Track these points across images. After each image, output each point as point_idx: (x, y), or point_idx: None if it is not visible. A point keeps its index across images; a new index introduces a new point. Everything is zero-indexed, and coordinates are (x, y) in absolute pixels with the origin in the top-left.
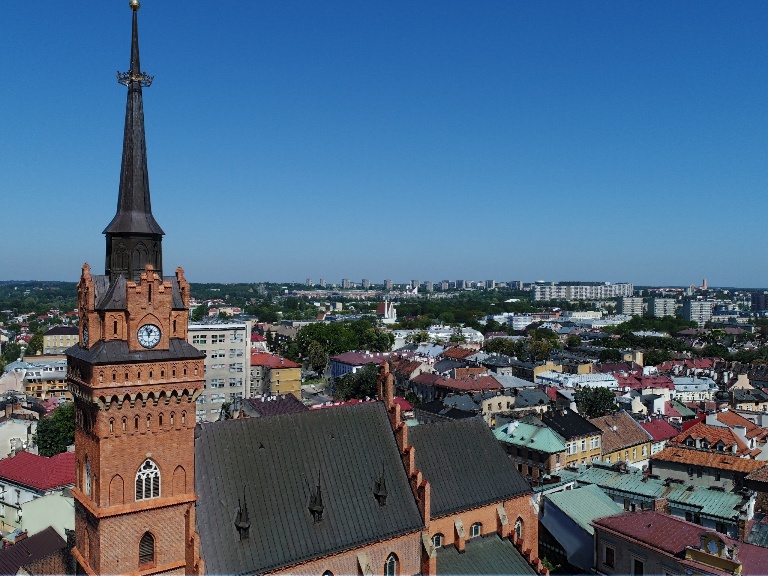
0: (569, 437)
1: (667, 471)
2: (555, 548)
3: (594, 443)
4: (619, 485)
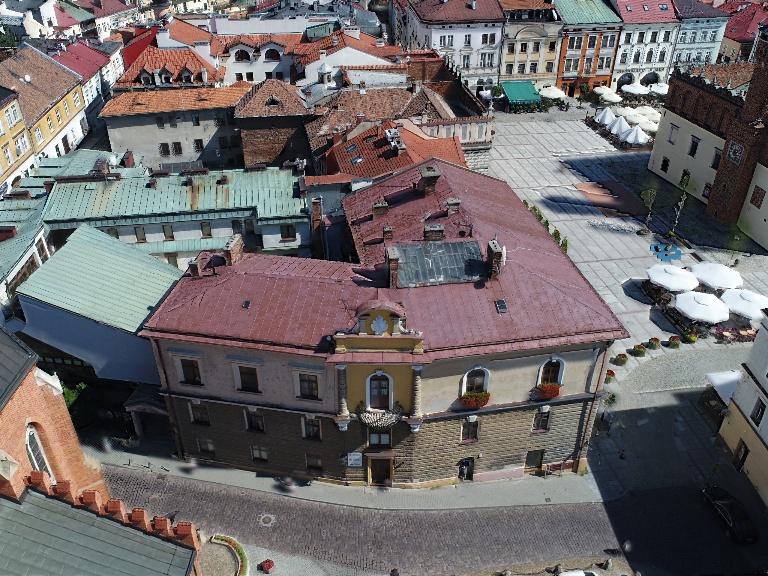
0: None
1: (129, 129)
2: (63, 360)
3: (11, 116)
4: (119, 208)
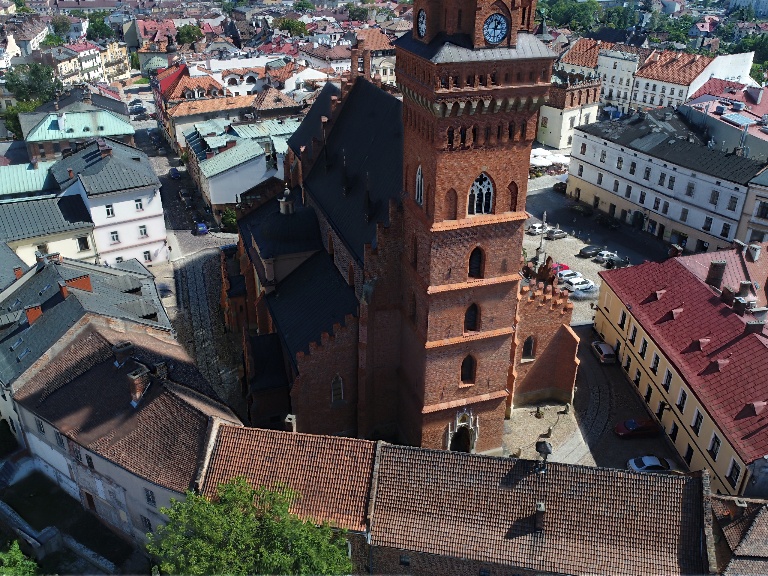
0: None
1: (189, 125)
2: None
3: None
4: (276, 131)
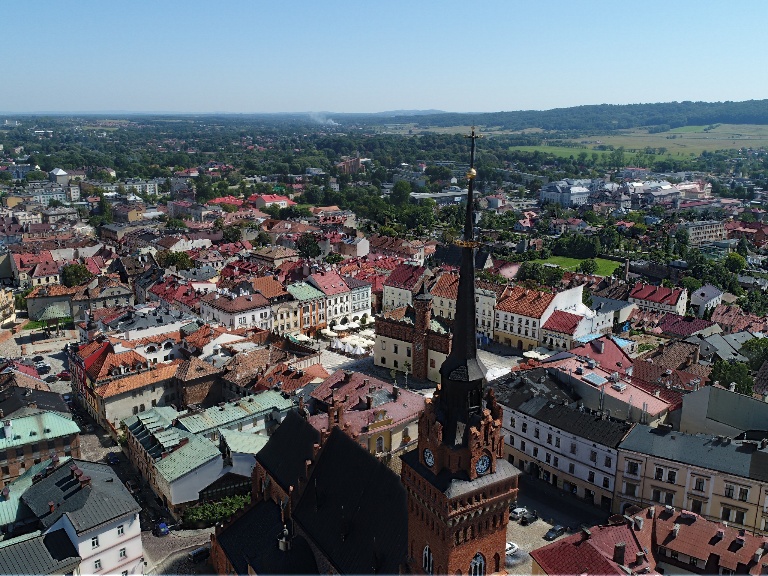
0: (68, 411)
1: (118, 402)
2: (240, 484)
3: None
4: (220, 421)
